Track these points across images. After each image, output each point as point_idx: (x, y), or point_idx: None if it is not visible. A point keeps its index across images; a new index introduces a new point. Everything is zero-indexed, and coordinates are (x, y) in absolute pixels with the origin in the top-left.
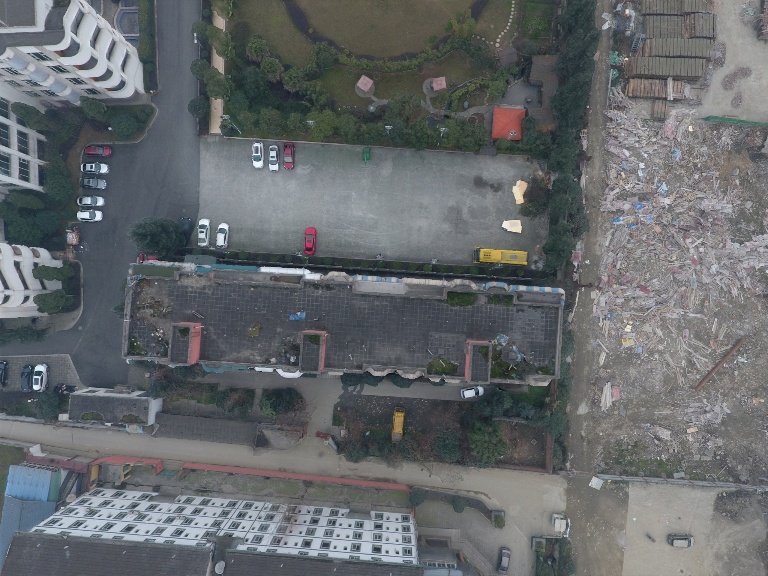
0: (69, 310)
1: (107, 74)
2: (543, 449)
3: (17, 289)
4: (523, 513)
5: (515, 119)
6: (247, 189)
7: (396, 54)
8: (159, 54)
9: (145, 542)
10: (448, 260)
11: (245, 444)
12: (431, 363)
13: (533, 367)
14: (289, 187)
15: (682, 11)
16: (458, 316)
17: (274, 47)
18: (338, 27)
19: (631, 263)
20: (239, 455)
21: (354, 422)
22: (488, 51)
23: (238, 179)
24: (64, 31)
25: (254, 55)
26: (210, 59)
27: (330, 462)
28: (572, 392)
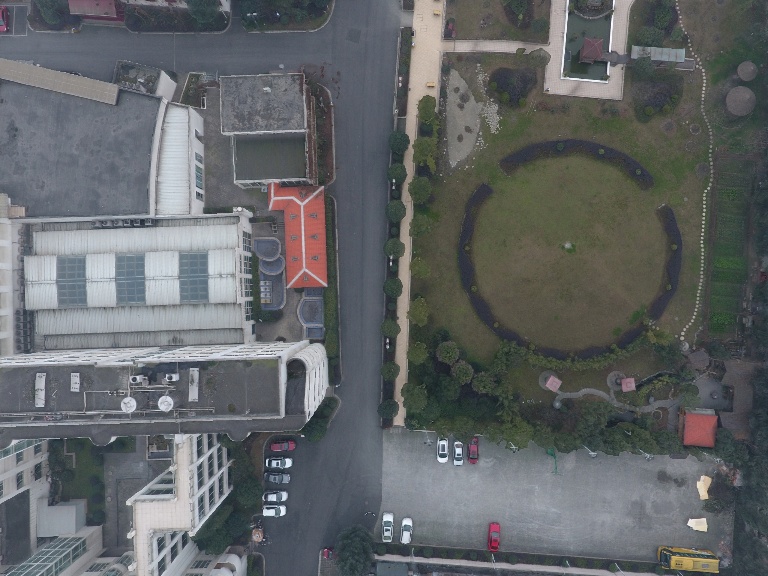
0: None
1: None
2: None
3: None
4: None
5: (710, 431)
6: (430, 482)
7: (580, 346)
8: (342, 344)
9: None
10: (631, 555)
11: None
12: None
13: None
14: (472, 480)
15: None
16: None
17: (457, 338)
18: (522, 318)
19: None
20: None
21: None
22: (679, 355)
23: (421, 471)
24: (306, 416)
25: (447, 363)
26: (395, 352)
27: None
28: None
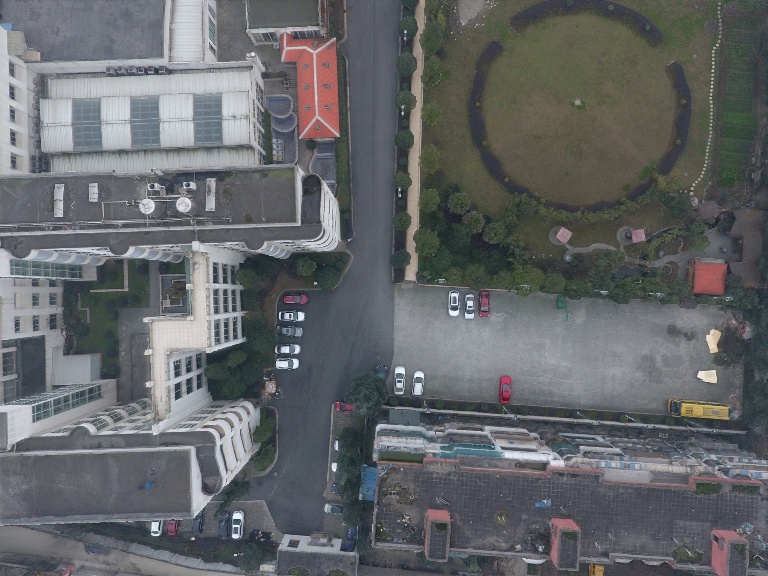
0: None
1: None
2: None
3: (242, 457)
4: None
5: (720, 277)
6: (441, 336)
7: (590, 202)
8: (354, 201)
9: None
10: (642, 409)
11: None
12: (676, 551)
13: None
14: (483, 334)
15: None
16: (703, 504)
17: (468, 194)
18: (532, 174)
19: None
20: None
21: (549, 571)
22: (689, 205)
23: (432, 326)
24: (322, 225)
25: (459, 210)
26: (406, 207)
27: None
28: None
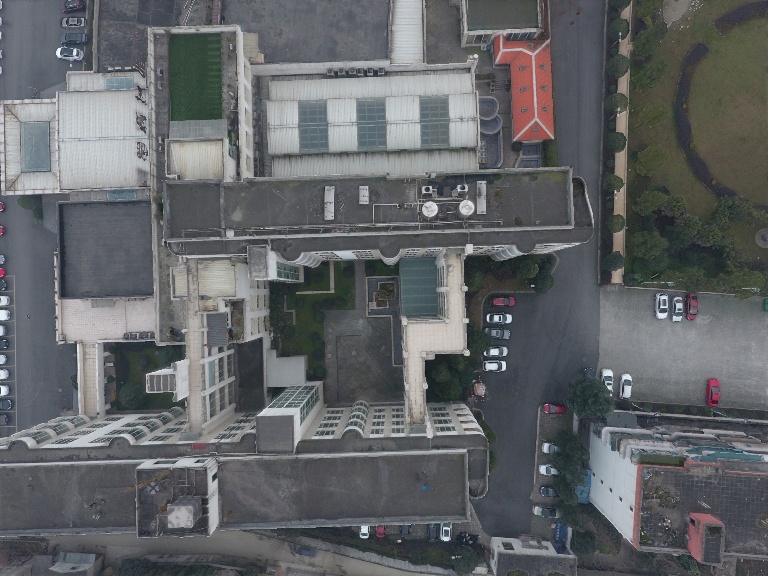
0: None
1: None
2: None
3: None
4: None
5: None
6: (647, 339)
7: None
8: None
9: None
10: None
11: None
12: None
13: None
14: (689, 337)
15: None
16: None
17: None
18: (737, 177)
19: None
20: None
21: (757, 574)
22: None
23: (638, 329)
24: None
25: (676, 213)
26: (613, 210)
27: None
28: None
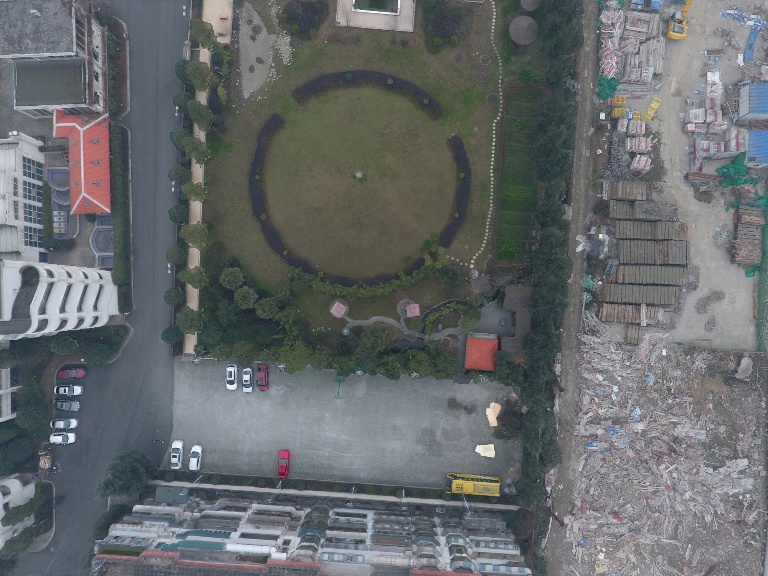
0: (41, 533)
1: (78, 324)
2: None
3: None
4: None
5: (487, 353)
6: (221, 409)
7: (371, 275)
8: (134, 273)
9: None
10: (421, 482)
11: None
12: None
13: None
14: (263, 408)
15: (655, 237)
16: None
17: (249, 267)
18: (313, 247)
19: (604, 488)
20: None
21: None
22: (461, 280)
23: (212, 399)
24: (31, 320)
25: (227, 287)
26: None
27: None
28: None
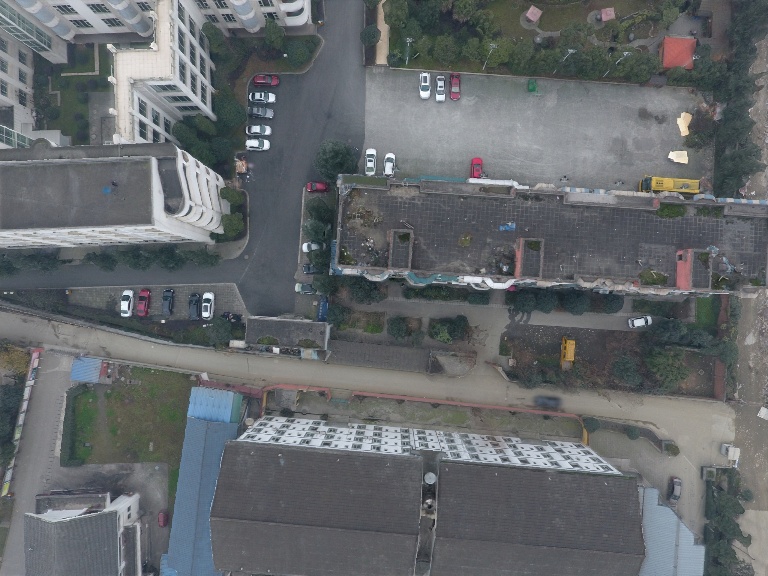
0: (236, 239)
1: None
2: (710, 379)
3: (208, 207)
4: (692, 443)
5: (689, 47)
6: (412, 120)
7: None
8: None
9: (357, 451)
10: None
11: (417, 371)
12: (641, 274)
13: (746, 277)
14: (454, 118)
15: None
16: (667, 227)
17: None
18: None
19: None
20: (406, 384)
21: (521, 352)
22: None
23: (403, 110)
24: None
25: None
26: None
27: (498, 391)
28: (739, 322)
